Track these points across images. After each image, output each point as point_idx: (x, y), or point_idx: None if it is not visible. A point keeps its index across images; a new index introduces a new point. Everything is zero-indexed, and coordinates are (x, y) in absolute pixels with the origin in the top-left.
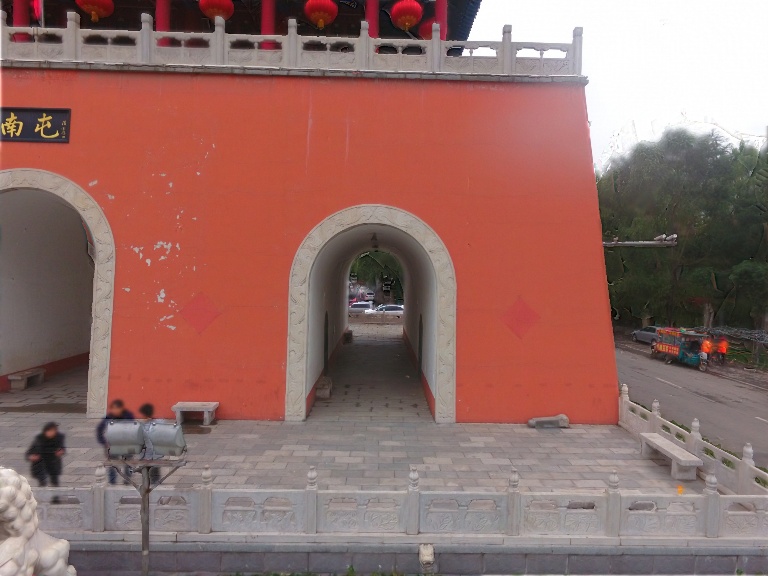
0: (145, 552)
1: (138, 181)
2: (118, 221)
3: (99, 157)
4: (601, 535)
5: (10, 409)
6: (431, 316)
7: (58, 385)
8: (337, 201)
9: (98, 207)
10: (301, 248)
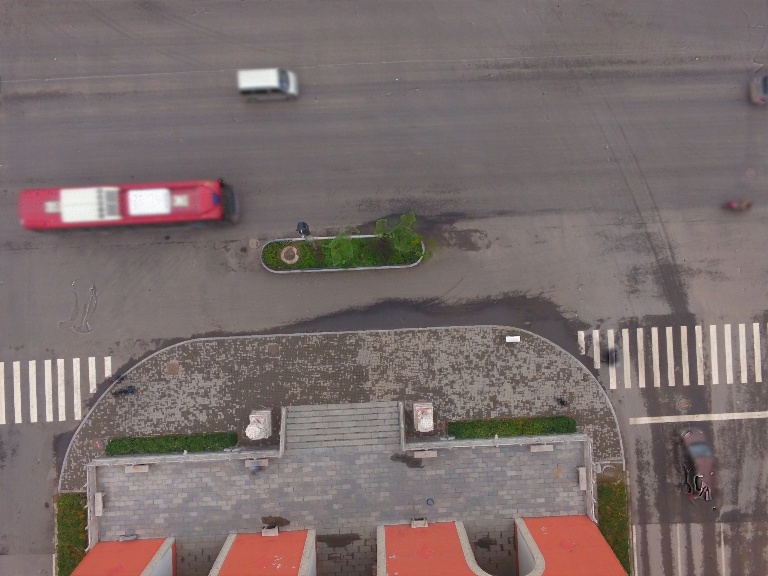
0: (239, 441)
1: None
2: None
3: None
4: None
5: (355, 537)
6: None
7: (363, 575)
8: None
9: None
10: None
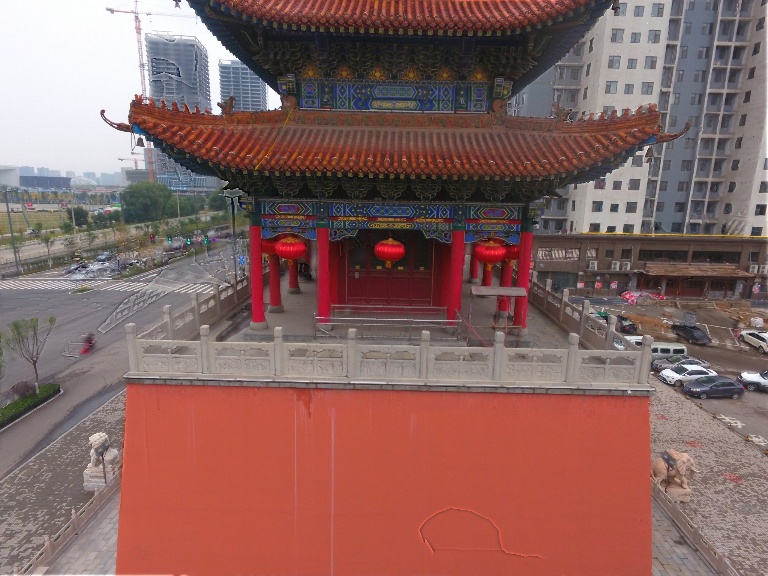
0: None
1: None
2: None
3: None
4: None
5: None
6: None
7: None
8: None
9: None
10: None
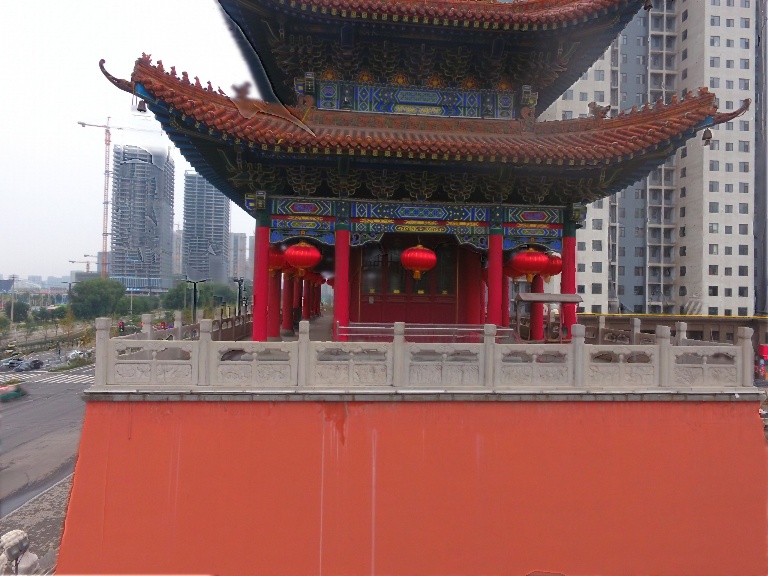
0: None
1: None
2: None
3: None
4: None
5: None
6: None
7: None
8: None
9: None
10: None
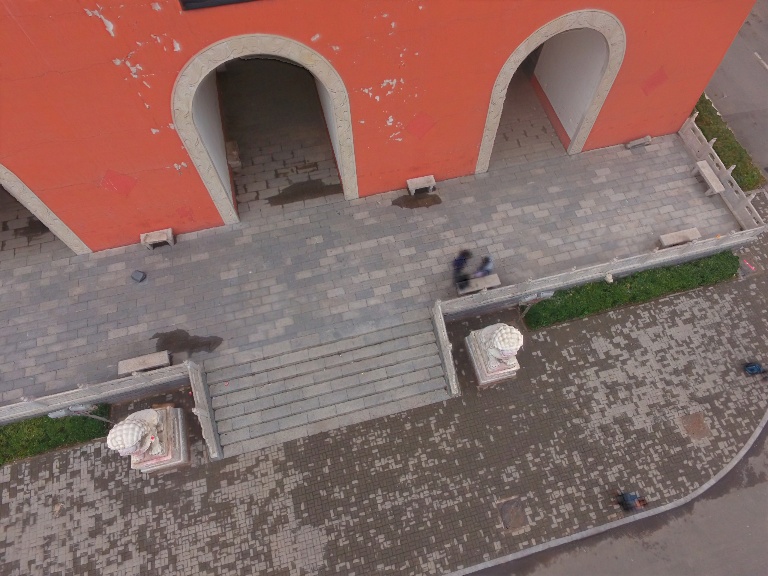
0: None
1: (360, 26)
2: (345, 69)
3: (315, 7)
4: (676, 254)
5: (277, 200)
6: (578, 69)
7: (256, 151)
8: (548, 11)
9: (325, 61)
10: (507, 62)
